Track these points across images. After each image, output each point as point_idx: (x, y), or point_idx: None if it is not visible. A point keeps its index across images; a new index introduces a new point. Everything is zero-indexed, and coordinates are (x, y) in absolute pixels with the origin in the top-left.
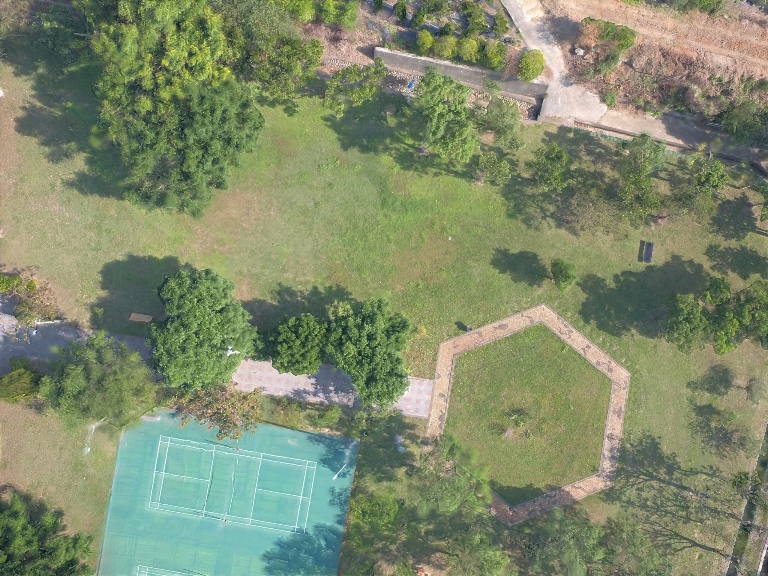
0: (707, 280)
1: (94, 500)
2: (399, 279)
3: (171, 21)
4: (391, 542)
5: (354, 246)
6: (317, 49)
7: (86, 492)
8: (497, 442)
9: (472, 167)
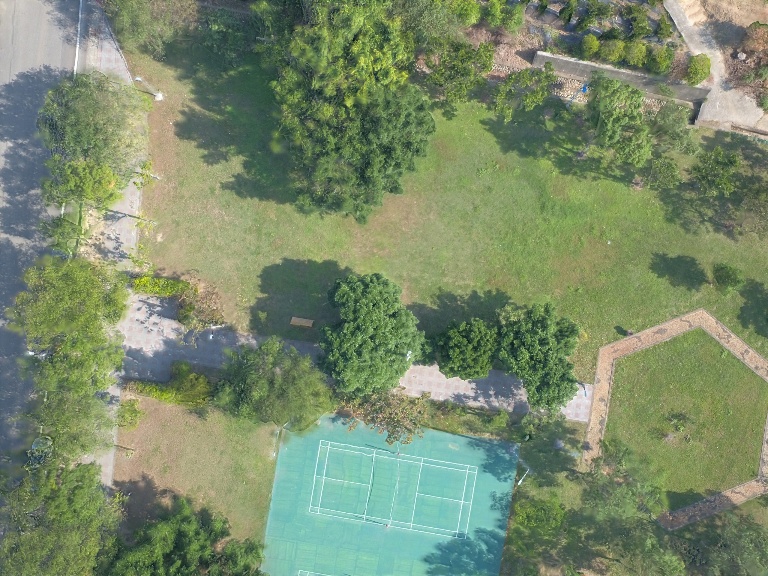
0: None
1: (254, 505)
2: (558, 283)
3: (357, 25)
4: (551, 547)
5: (513, 250)
6: (489, 53)
7: (246, 497)
8: (657, 447)
9: (631, 171)
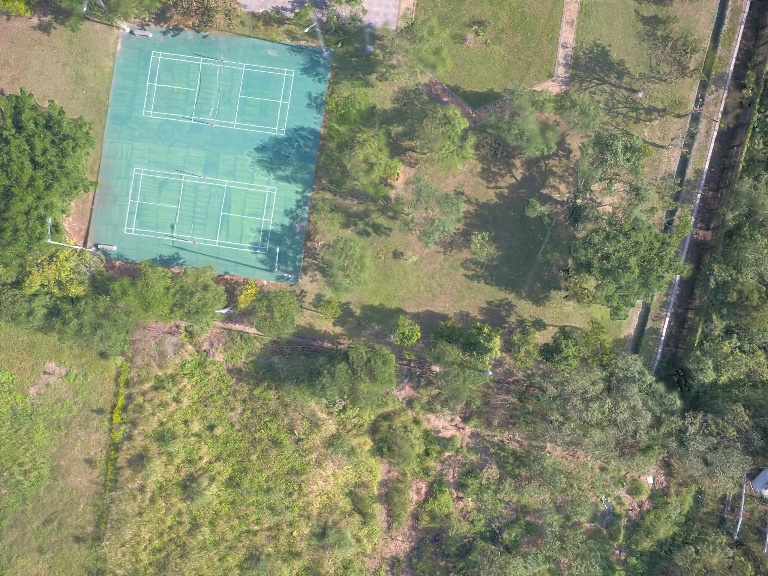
0: None
1: (93, 111)
2: None
3: None
4: None
5: None
6: None
7: (86, 104)
8: (459, 51)
9: None
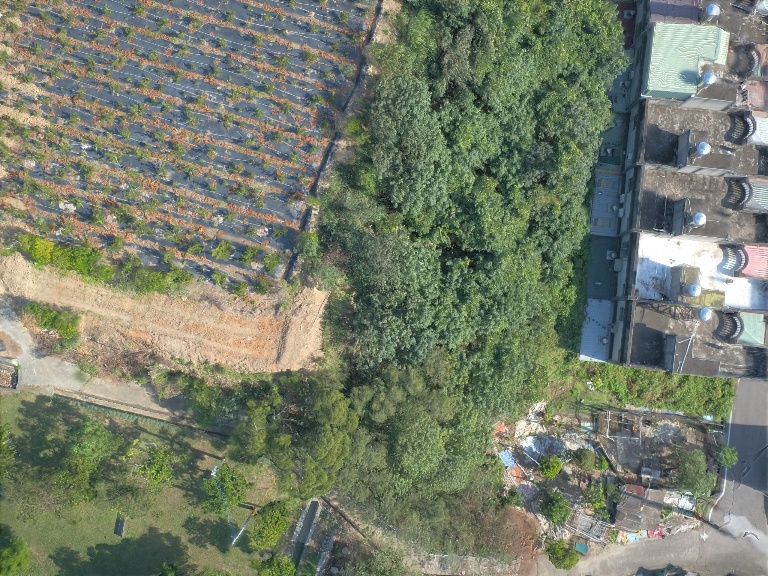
0: (185, 553)
1: None
2: None
3: None
4: None
5: None
6: None
7: None
8: None
9: None
